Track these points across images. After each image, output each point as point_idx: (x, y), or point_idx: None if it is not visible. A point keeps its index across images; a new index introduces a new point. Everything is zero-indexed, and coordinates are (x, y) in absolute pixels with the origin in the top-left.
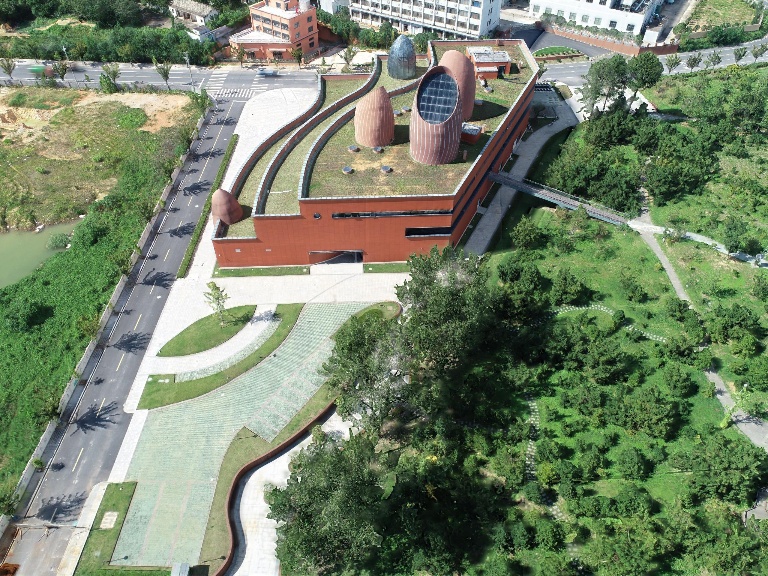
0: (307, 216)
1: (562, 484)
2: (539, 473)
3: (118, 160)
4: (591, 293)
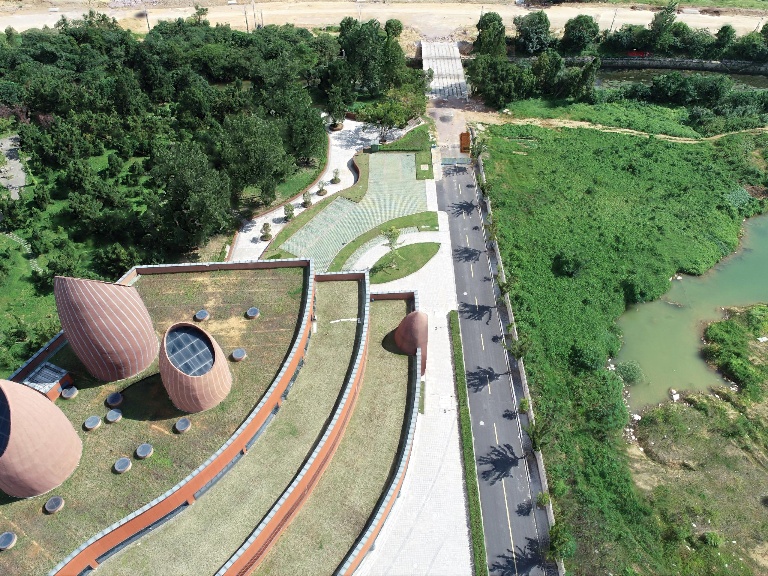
0: None
1: None
2: None
3: (672, 534)
4: (39, 277)
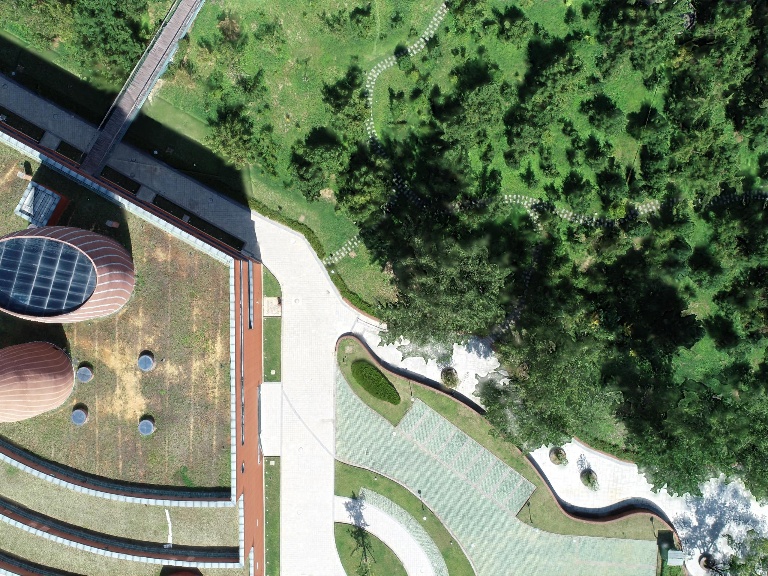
0: (242, 483)
1: (636, 199)
2: (612, 217)
3: None
4: (352, 83)
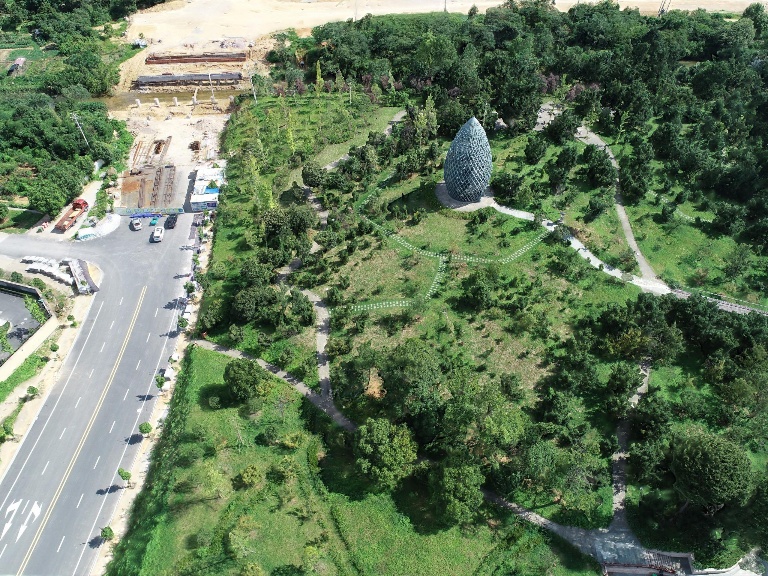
0: None
1: None
2: None
3: None
4: (703, 222)
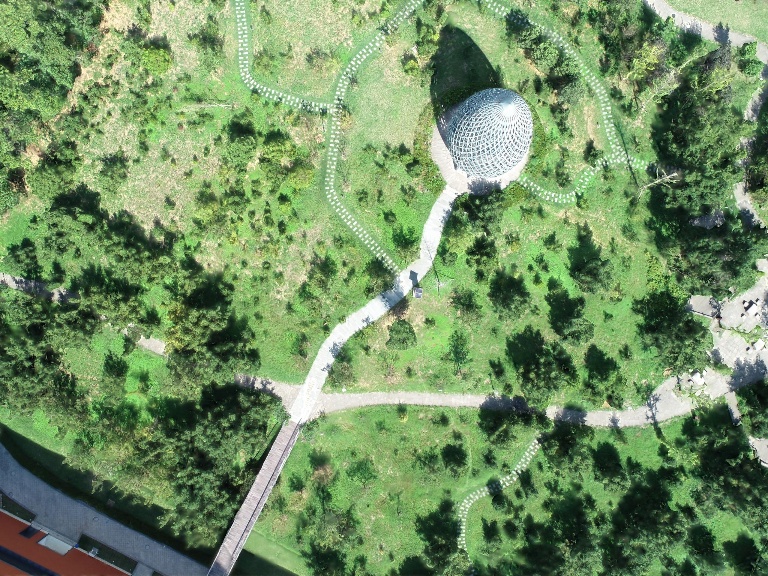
0: None
1: None
2: None
3: None
4: (446, 520)
